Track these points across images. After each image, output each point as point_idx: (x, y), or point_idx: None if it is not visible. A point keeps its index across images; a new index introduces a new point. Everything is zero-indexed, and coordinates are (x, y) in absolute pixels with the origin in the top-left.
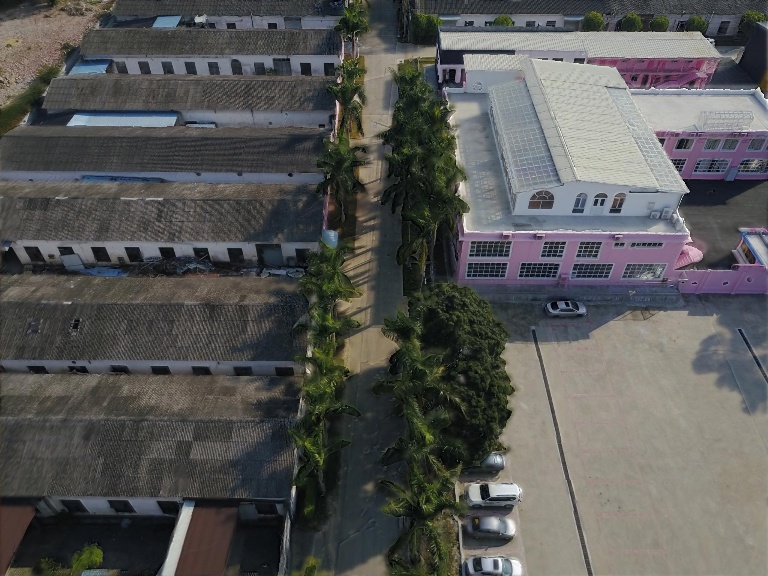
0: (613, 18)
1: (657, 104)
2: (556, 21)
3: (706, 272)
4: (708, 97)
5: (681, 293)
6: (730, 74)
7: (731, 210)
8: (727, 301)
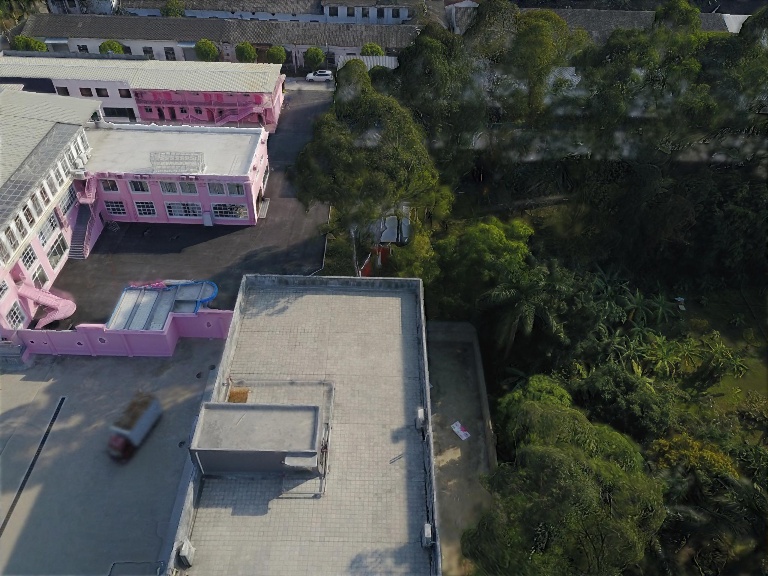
0: (232, 46)
1: (145, 141)
2: (173, 48)
3: (42, 332)
4: (209, 135)
5: (37, 354)
6: (322, 109)
7: (178, 259)
8: (81, 364)
